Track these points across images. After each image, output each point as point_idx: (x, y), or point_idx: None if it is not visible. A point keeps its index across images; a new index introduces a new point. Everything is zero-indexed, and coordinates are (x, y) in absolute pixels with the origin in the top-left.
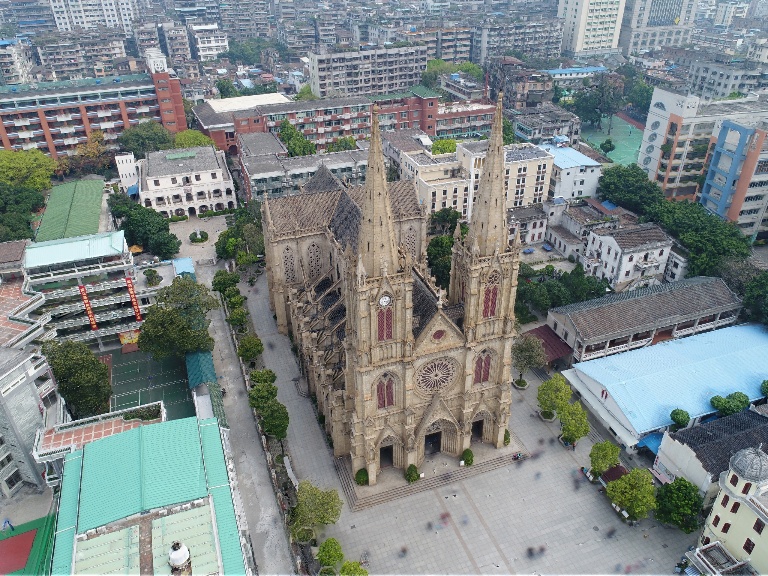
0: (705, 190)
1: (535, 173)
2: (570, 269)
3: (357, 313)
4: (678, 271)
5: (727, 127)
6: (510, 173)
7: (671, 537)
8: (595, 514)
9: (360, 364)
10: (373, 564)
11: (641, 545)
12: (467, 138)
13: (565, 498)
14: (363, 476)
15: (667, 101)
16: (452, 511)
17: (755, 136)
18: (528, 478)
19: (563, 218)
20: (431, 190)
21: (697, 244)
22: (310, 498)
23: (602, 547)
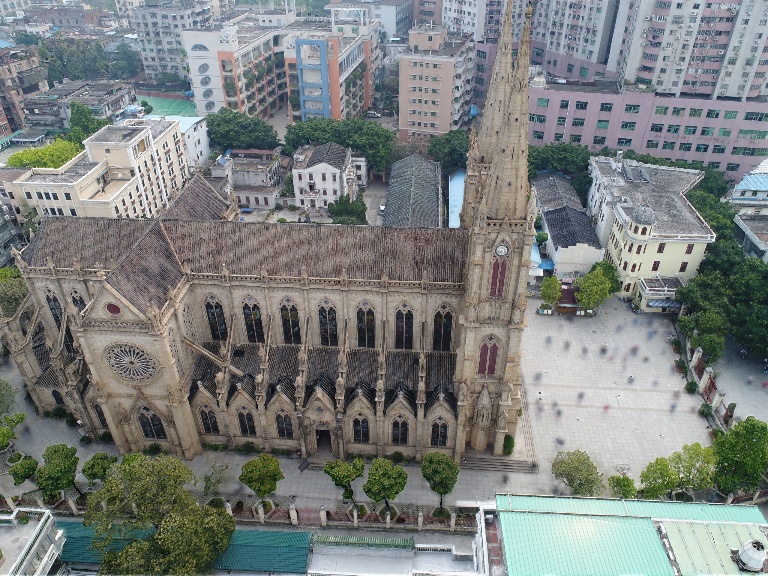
0: (303, 106)
1: (173, 145)
2: (290, 215)
3: (526, 263)
4: (363, 171)
5: (300, 45)
6: (159, 153)
7: (609, 303)
8: (581, 326)
9: (520, 321)
10: (604, 476)
11: (613, 318)
12: (1, 150)
13: (562, 334)
14: (513, 441)
15: (207, 41)
16: (557, 401)
17: (329, 45)
18: (535, 344)
19: (235, 176)
20: (113, 206)
21: (369, 141)
22: (585, 467)
23: (611, 336)
